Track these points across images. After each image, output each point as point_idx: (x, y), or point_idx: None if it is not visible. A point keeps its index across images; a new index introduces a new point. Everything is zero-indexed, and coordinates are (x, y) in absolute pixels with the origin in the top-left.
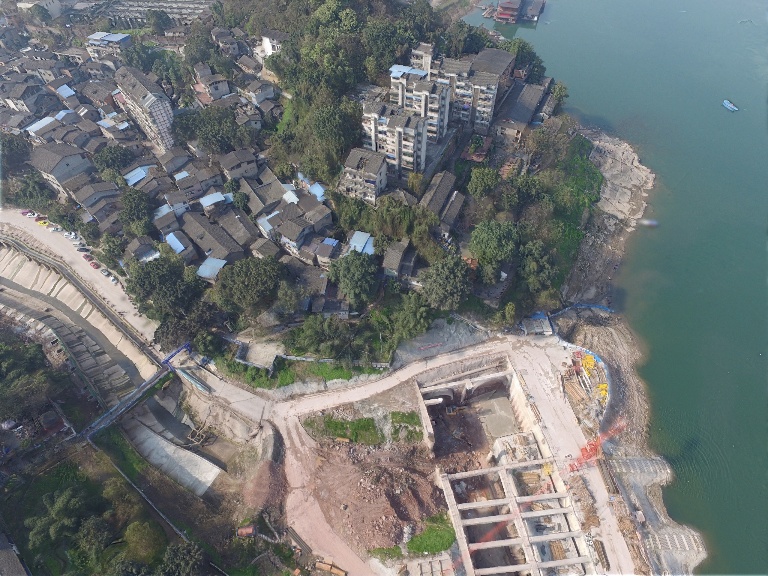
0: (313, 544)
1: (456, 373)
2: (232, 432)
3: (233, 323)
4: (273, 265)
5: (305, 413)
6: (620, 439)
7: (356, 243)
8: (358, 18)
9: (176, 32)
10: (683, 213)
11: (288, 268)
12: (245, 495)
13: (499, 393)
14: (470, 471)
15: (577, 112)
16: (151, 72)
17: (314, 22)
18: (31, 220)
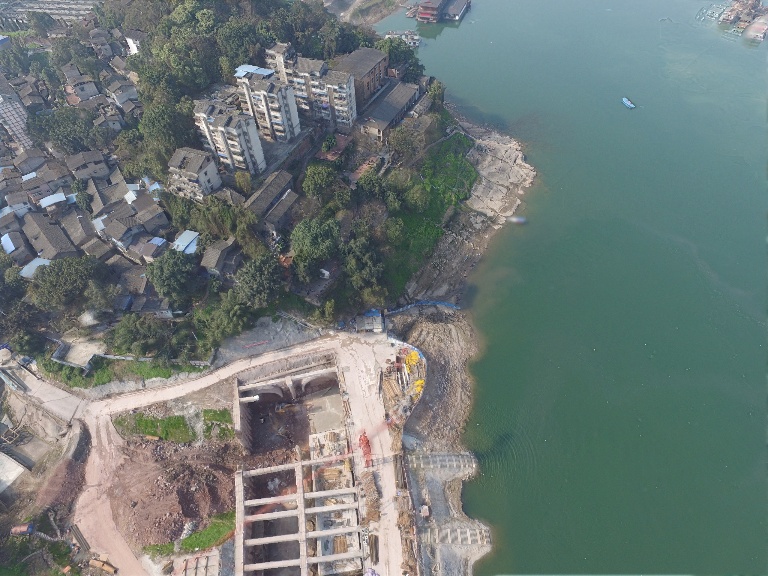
0: (93, 541)
1: (281, 371)
2: (44, 431)
3: (56, 323)
4: (87, 265)
5: (118, 412)
6: (429, 435)
7: (180, 242)
8: (218, 18)
9: (58, 33)
10: (555, 210)
11: (114, 268)
12: (39, 494)
13: (333, 390)
14: (266, 468)
15: (475, 111)
16: (30, 74)
17: (165, 23)
18: None
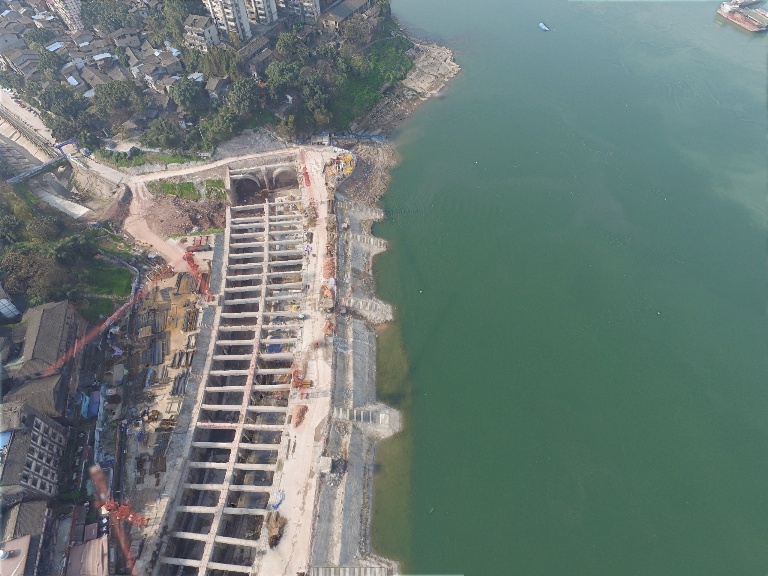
0: (137, 236)
1: (259, 165)
2: (101, 192)
3: (107, 129)
4: (130, 84)
5: (149, 180)
6: (354, 197)
7: None
8: None
9: None
10: (469, 91)
11: (146, 94)
12: None
13: (295, 187)
14: None
15: (422, 31)
16: None
17: None
18: None
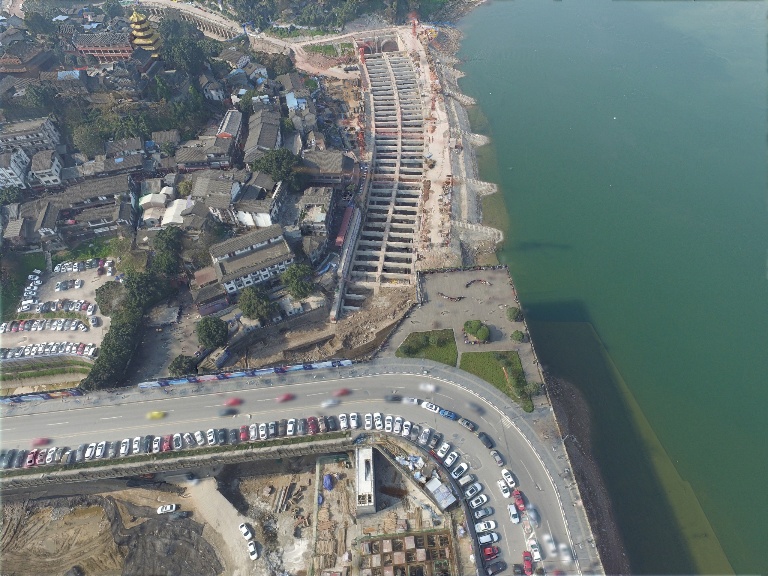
0: None
1: None
2: None
3: (272, 16)
4: None
5: None
6: (440, 51)
7: None
8: None
9: None
10: None
11: None
12: None
13: None
14: None
15: None
16: None
17: None
18: (168, 1)
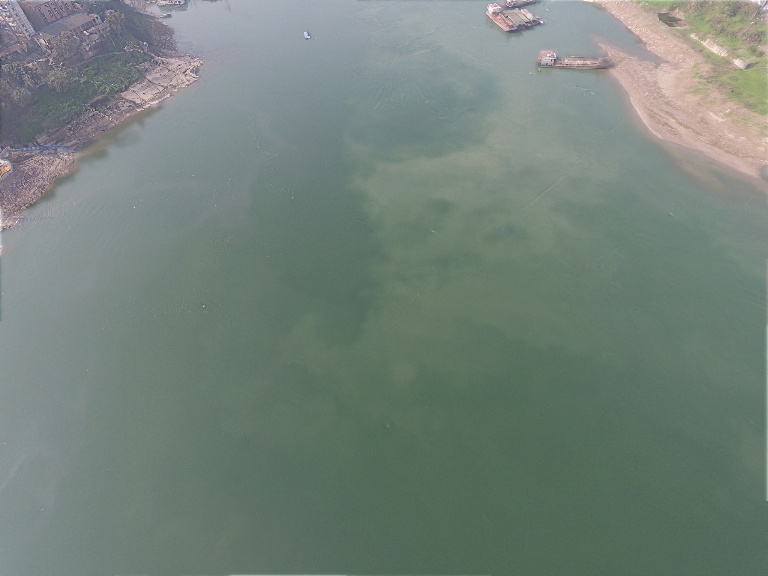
0: None
1: None
2: None
3: None
4: None
5: None
6: None
7: None
8: None
9: None
10: (191, 100)
11: None
12: None
13: None
14: None
15: (188, 44)
16: None
17: None
18: None
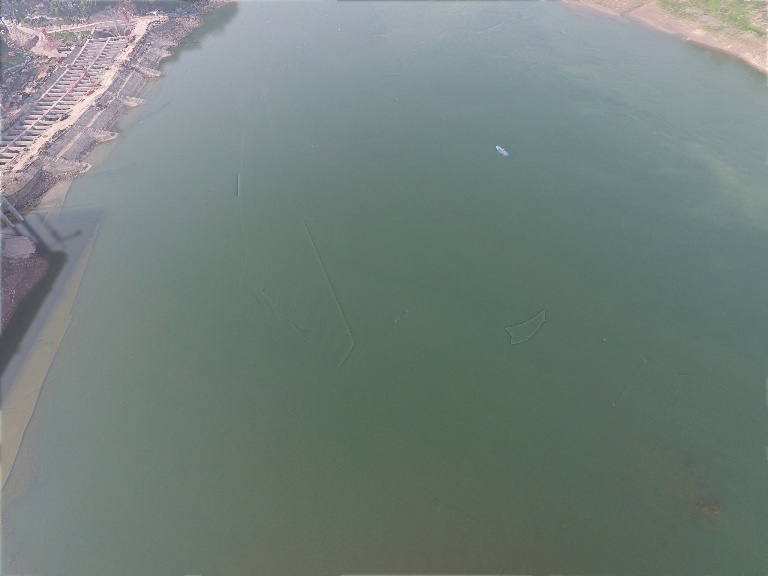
0: None
1: None
2: (23, 40)
3: (28, 9)
4: None
5: None
6: (163, 36)
7: None
8: None
9: None
10: None
11: None
12: None
13: None
14: None
15: None
16: None
17: None
18: None
